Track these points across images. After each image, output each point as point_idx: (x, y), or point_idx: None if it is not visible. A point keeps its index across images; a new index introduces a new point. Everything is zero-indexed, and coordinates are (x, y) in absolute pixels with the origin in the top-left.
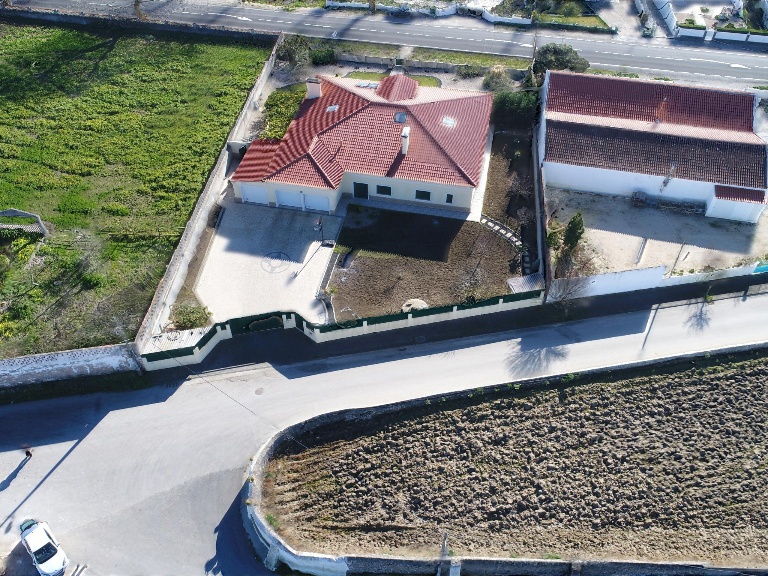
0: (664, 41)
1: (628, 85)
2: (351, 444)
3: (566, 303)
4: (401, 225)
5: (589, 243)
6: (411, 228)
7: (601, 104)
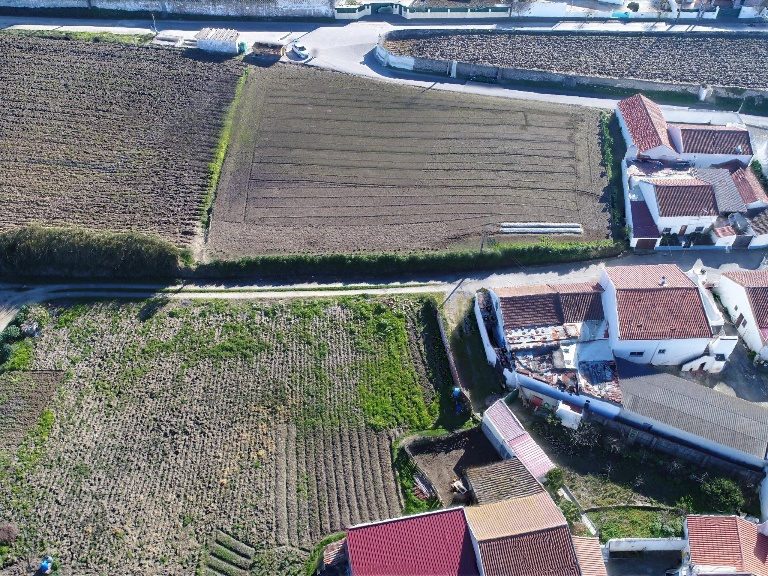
0: None
1: None
2: (419, 40)
3: (520, 17)
4: None
5: None
6: None
7: None
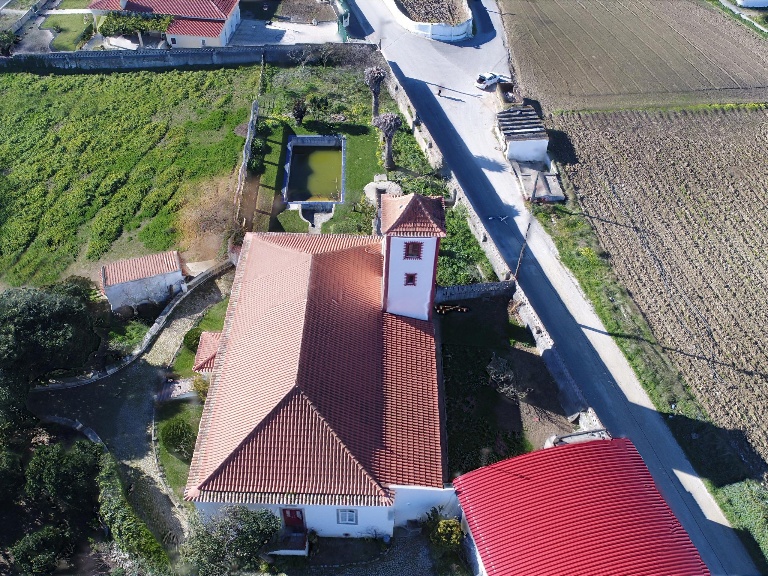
0: None
1: None
2: (412, 14)
3: None
4: (252, 4)
5: None
6: (256, 1)
7: None
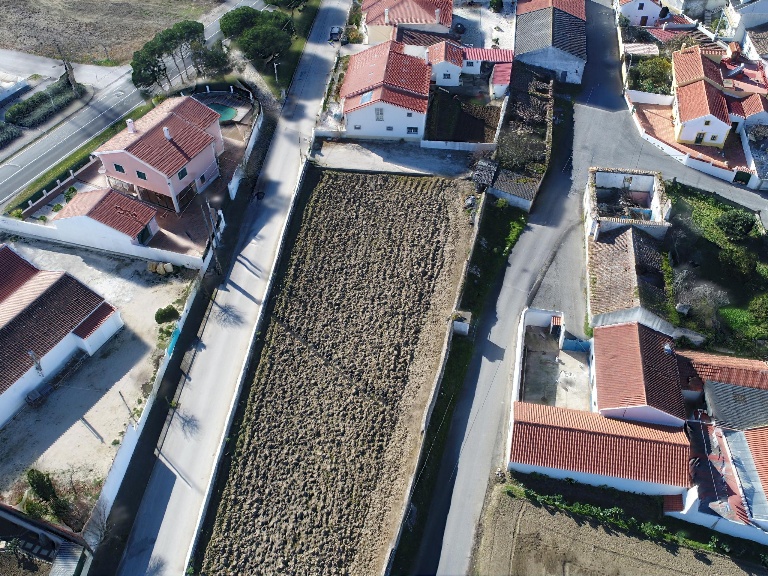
0: None
1: None
2: None
3: (106, 532)
4: None
5: (52, 472)
6: None
7: None
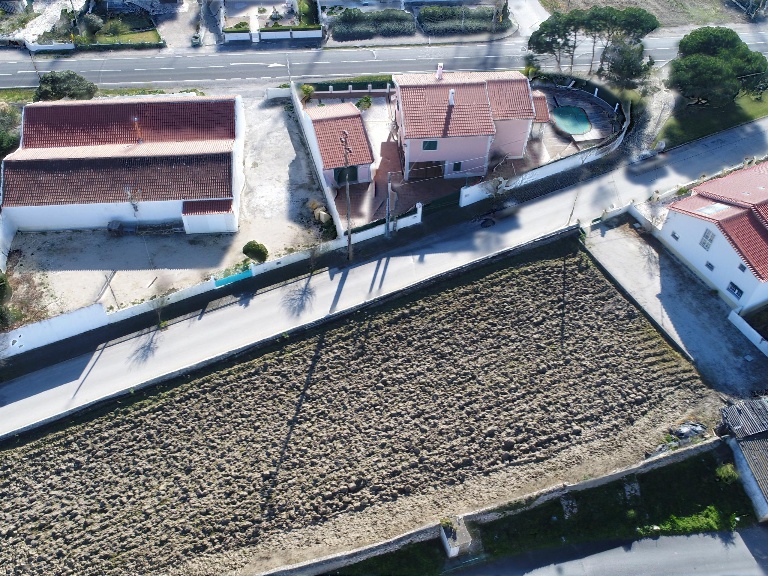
0: (212, 49)
1: (108, 108)
2: None
3: (0, 364)
4: None
5: (49, 288)
6: None
7: (81, 133)
